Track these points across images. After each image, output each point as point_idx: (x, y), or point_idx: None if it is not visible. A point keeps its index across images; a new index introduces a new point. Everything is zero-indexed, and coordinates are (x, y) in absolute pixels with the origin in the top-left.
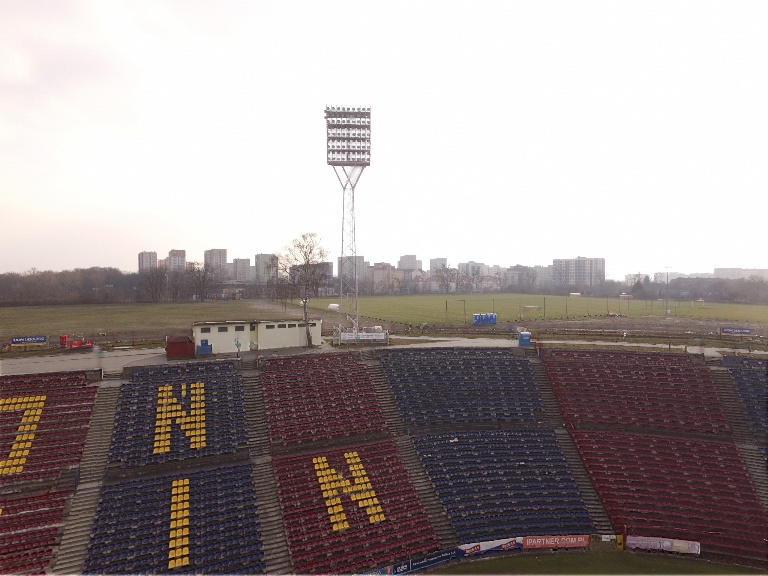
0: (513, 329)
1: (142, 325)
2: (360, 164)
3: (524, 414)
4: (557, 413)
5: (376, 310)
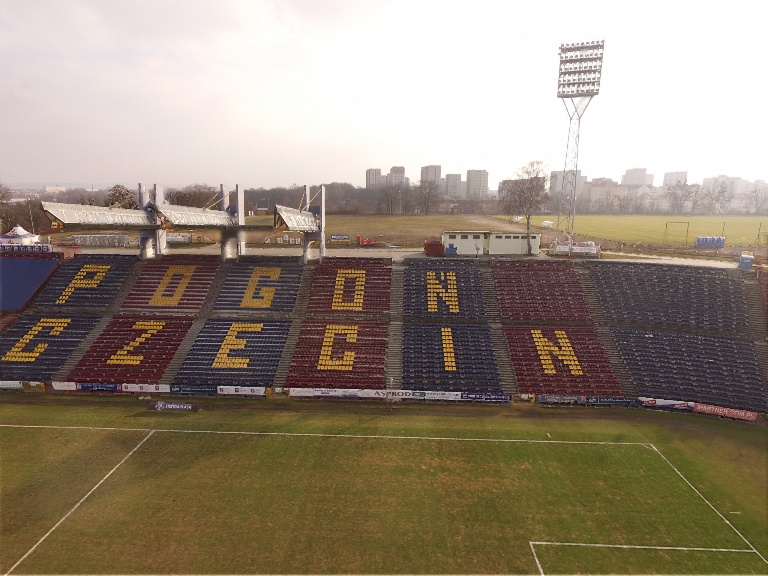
0: (740, 253)
1: (395, 232)
2: (589, 95)
3: (725, 325)
4: (762, 329)
5: (590, 229)
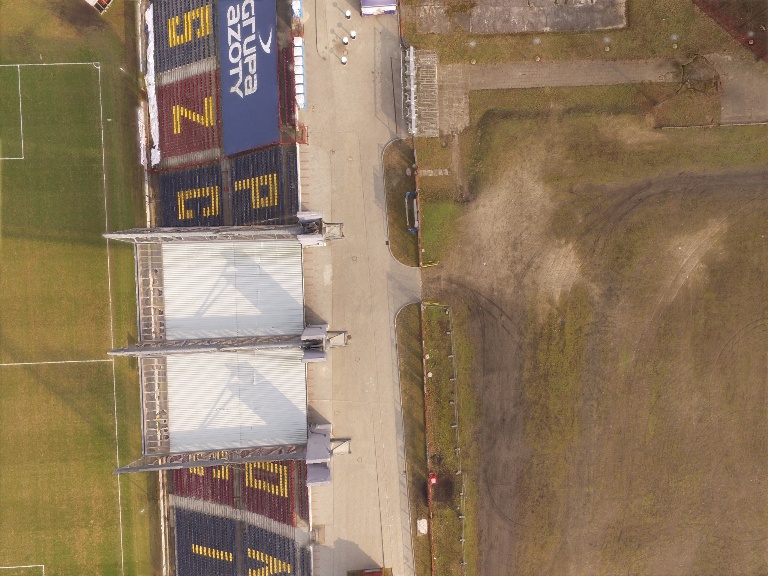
0: None
1: (616, 518)
2: None
3: None
4: None
5: None
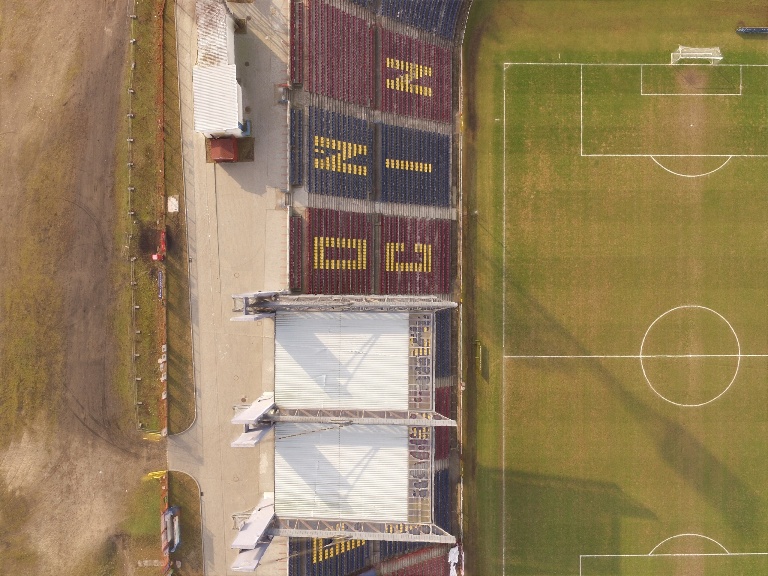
0: None
1: None
2: None
3: None
4: None
5: None
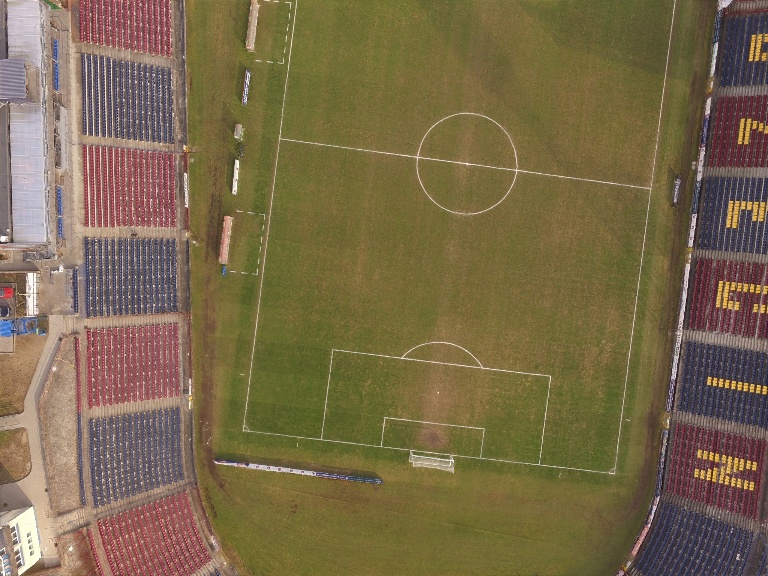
0: None
1: None
2: None
3: None
4: None
5: None
